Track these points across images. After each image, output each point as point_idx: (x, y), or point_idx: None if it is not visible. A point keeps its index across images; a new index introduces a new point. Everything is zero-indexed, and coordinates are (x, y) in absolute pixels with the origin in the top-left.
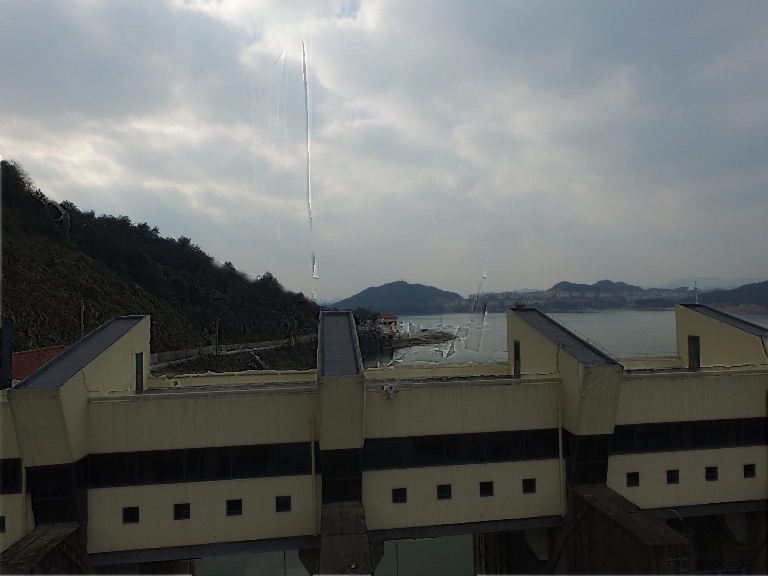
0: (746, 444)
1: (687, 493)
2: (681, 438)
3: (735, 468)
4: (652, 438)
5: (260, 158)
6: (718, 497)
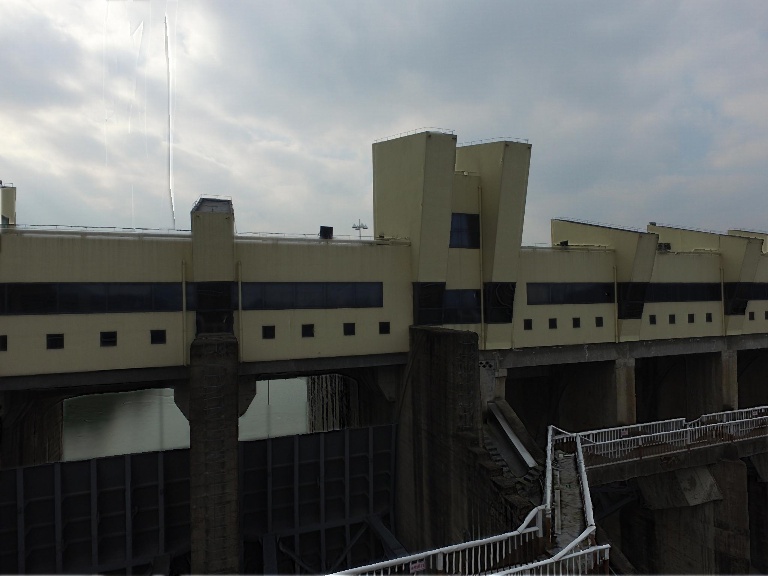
0: (157, 309)
1: (75, 359)
2: (76, 302)
3: (140, 333)
4: (35, 300)
5: (114, 136)
6: (116, 363)
